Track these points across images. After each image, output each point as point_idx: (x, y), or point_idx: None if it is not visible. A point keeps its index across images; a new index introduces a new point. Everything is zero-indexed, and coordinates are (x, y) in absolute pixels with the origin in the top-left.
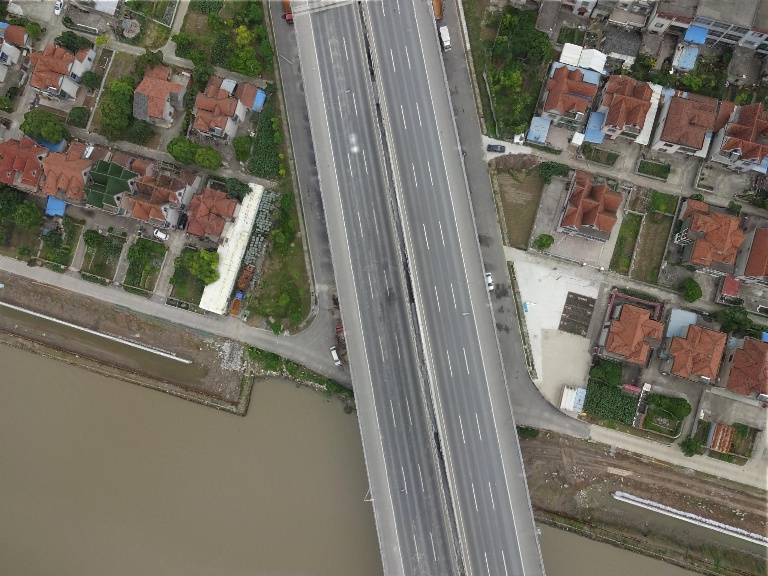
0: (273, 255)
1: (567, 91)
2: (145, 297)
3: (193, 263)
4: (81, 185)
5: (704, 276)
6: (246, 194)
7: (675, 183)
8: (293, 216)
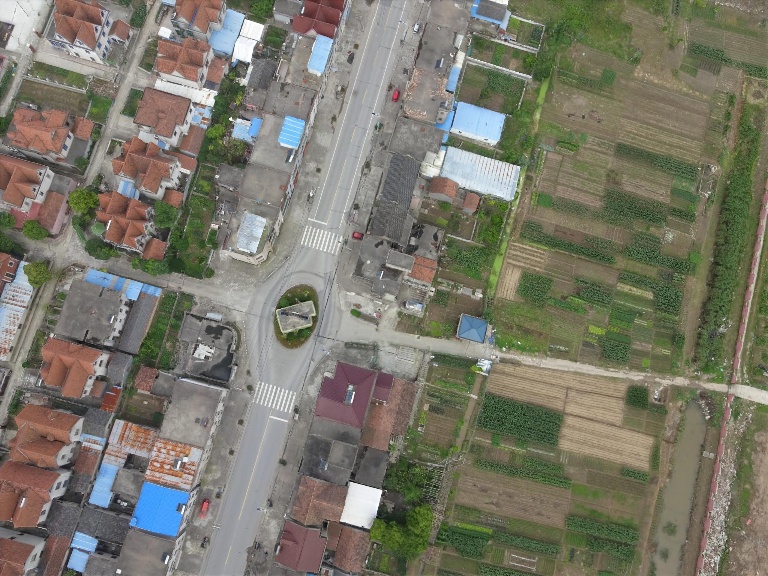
0: None
1: (198, 4)
2: None
3: None
4: None
5: None
6: None
7: (119, 123)
8: None
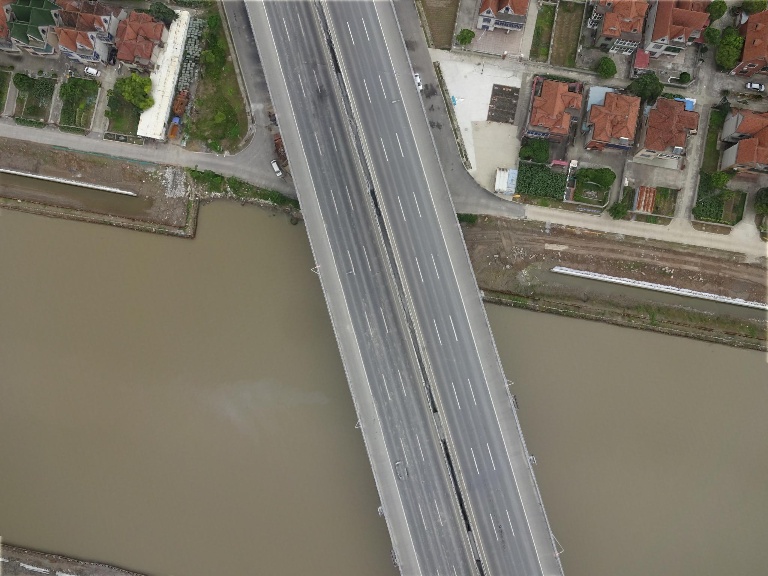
0: (206, 80)
1: None
2: (82, 135)
3: (125, 86)
4: (4, 23)
5: (617, 56)
6: (173, 21)
7: None
8: (222, 41)
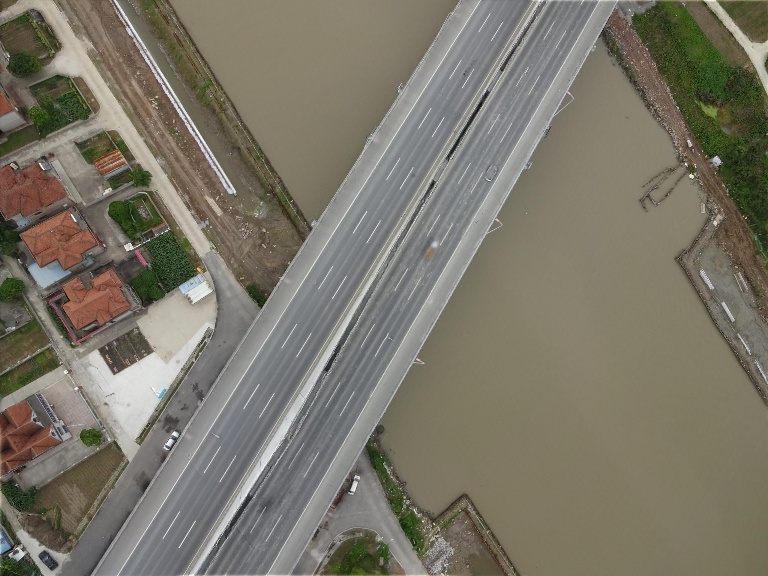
0: None
1: None
2: None
3: None
4: None
5: None
6: None
7: None
8: None
